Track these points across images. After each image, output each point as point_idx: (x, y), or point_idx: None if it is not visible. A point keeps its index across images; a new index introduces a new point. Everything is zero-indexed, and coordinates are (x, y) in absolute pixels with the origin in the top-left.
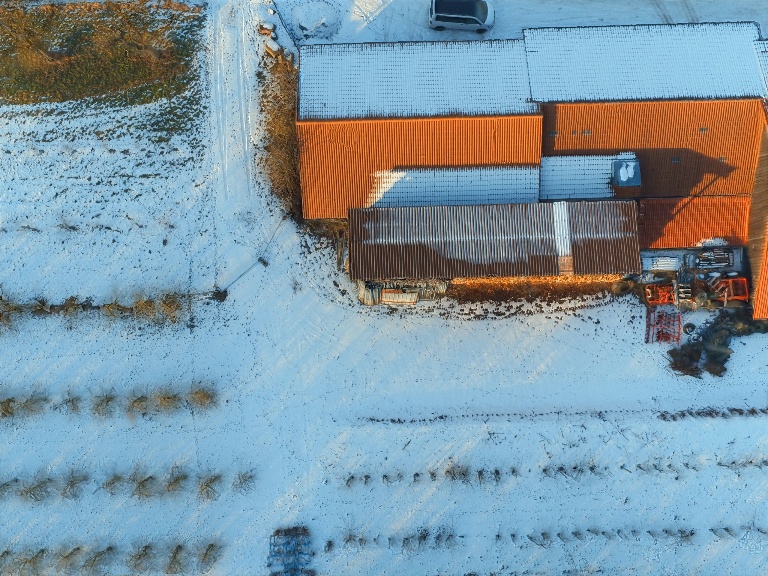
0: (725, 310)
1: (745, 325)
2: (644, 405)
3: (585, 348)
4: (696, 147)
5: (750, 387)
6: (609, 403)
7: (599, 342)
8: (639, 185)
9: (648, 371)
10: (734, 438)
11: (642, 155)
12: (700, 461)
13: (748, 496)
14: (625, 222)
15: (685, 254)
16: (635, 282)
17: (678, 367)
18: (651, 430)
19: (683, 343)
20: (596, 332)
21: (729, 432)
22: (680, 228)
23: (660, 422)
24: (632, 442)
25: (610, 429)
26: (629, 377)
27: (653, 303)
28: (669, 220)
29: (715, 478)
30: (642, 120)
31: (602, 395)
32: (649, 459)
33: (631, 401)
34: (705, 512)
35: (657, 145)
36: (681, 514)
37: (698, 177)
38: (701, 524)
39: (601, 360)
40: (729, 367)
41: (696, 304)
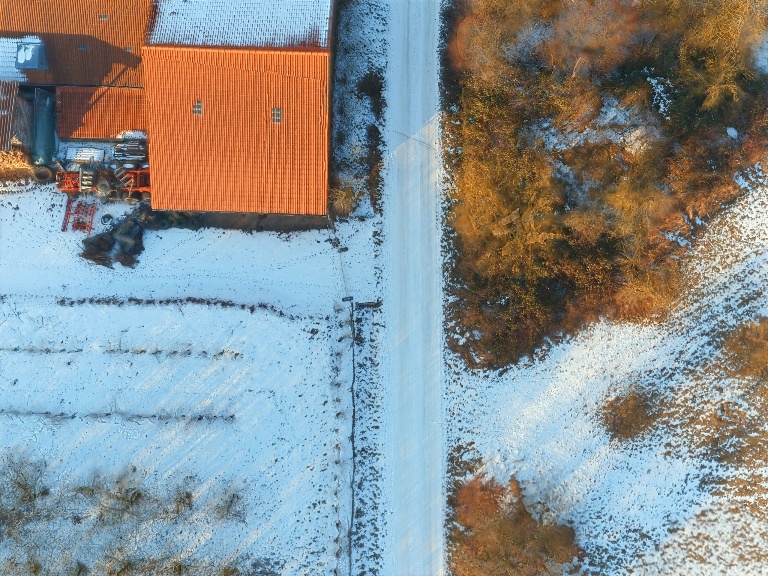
0: (146, 204)
1: (149, 216)
2: (52, 291)
3: (1, 233)
4: (98, 35)
5: (162, 280)
6: (19, 288)
7: (16, 228)
8: (35, 68)
9: (62, 259)
10: (128, 327)
11: (47, 40)
12: (94, 348)
13: (137, 384)
14: (2, 100)
15: (111, 146)
16: (54, 170)
17: (85, 255)
18: (47, 314)
19: (99, 233)
20: (14, 218)
21: (124, 320)
22: (99, 118)
23: (57, 307)
24: (27, 325)
25: (7, 311)
26: (43, 264)
27: (72, 192)
28: (87, 110)
29: (107, 365)
30: (39, 3)
31: (13, 280)
32: (43, 343)
33: (41, 287)
34: (92, 397)
35: (59, 30)
36: (68, 398)
37: (107, 66)
38: (86, 408)
39: (16, 245)
40: (142, 259)
41: (101, 193)
